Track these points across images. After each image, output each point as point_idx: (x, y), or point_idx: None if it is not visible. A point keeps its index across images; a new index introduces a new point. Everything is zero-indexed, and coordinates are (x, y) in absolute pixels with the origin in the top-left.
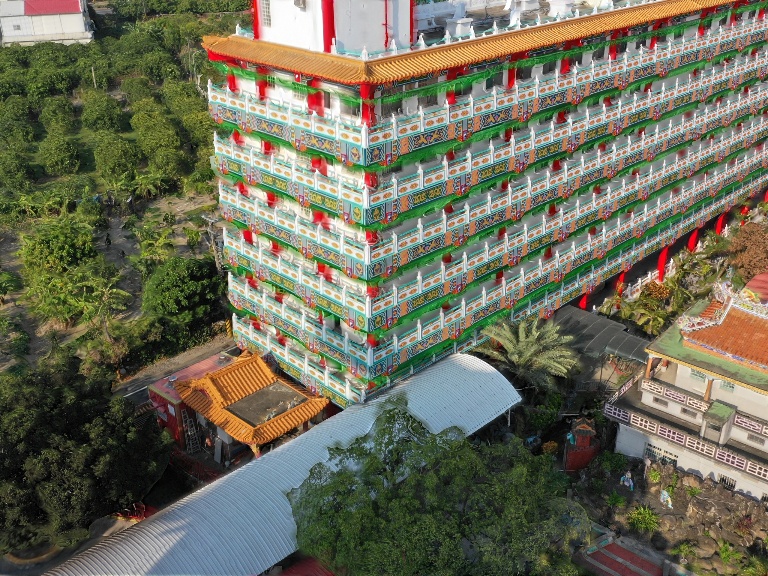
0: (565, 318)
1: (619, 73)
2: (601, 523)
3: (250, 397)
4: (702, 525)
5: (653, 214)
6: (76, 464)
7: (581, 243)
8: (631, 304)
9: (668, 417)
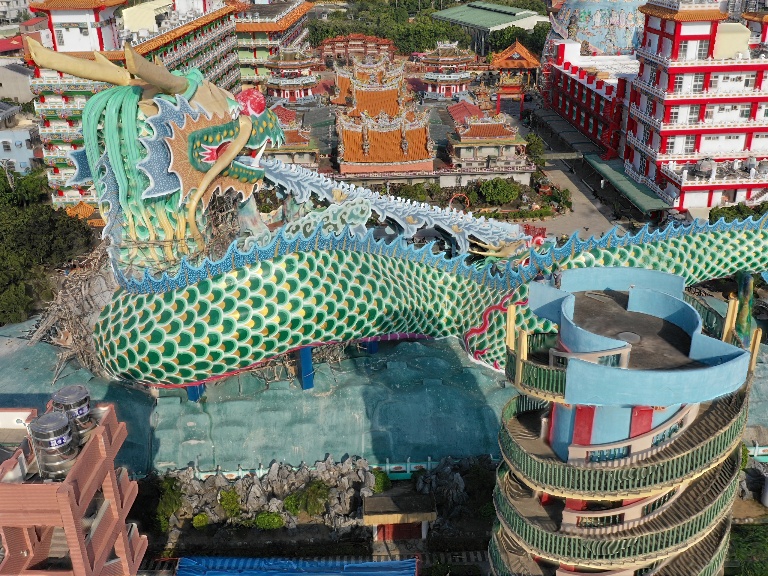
0: None
1: (182, 56)
2: None
3: (92, 216)
4: None
5: None
6: (77, 219)
7: None
8: None
9: None
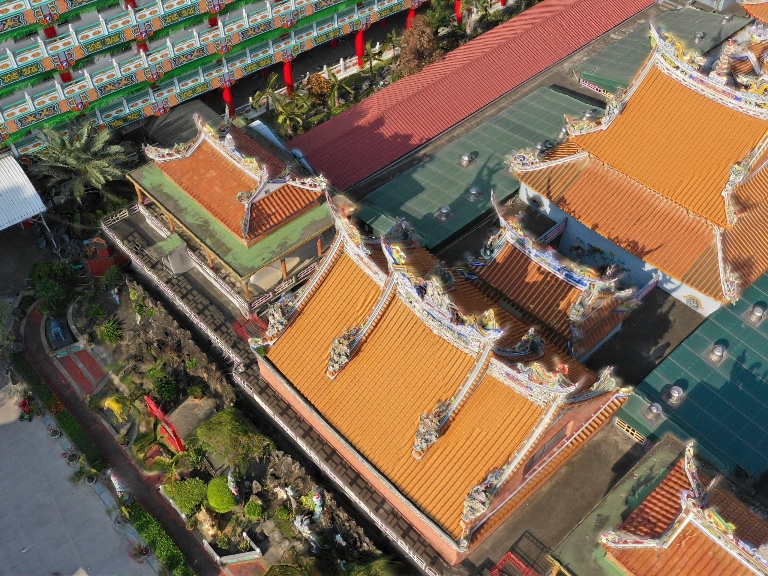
0: (178, 116)
1: None
2: (80, 331)
3: None
4: (146, 344)
5: (307, 1)
6: None
7: (182, 39)
8: (280, 99)
9: (159, 239)
